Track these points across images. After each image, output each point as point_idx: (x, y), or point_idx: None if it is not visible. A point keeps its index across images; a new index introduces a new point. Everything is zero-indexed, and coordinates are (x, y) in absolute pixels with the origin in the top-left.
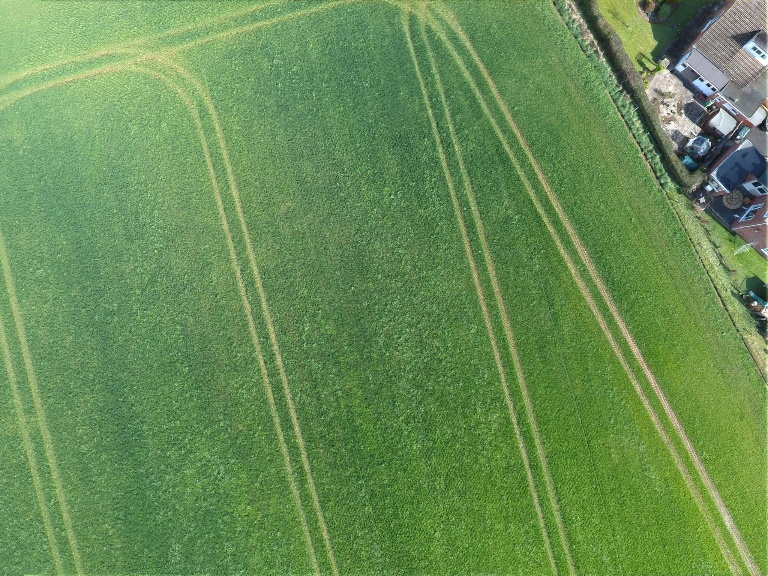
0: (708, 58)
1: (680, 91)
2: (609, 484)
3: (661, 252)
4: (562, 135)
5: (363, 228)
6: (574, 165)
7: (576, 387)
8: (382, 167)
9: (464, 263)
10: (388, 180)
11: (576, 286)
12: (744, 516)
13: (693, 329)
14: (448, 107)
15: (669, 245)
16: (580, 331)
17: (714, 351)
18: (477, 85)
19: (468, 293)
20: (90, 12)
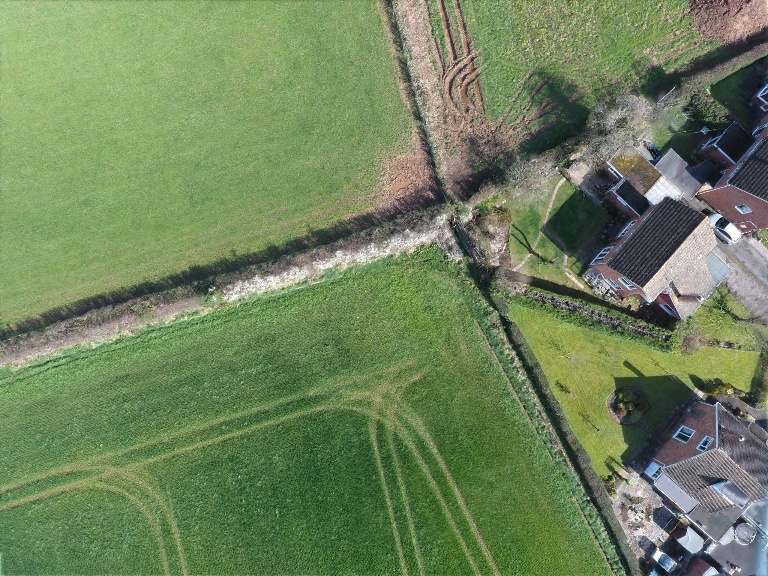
0: (676, 482)
1: (649, 495)
2: None
3: None
4: (527, 545)
5: None
6: None
7: None
8: None
9: None
10: None
11: None
12: None
13: None
14: (412, 520)
15: None
16: None
17: None
18: (443, 495)
19: None
20: (57, 429)
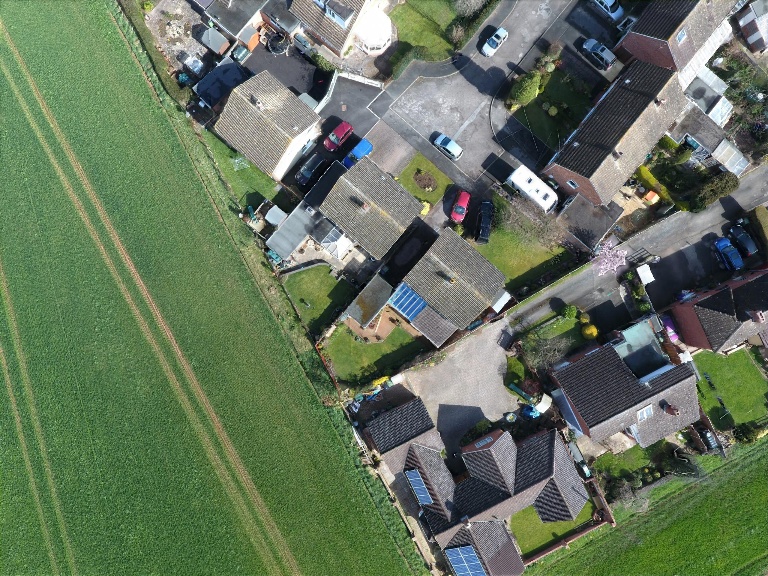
0: None
1: (187, 13)
2: (91, 390)
3: (159, 167)
4: (61, 54)
5: None
6: (72, 83)
7: (61, 296)
8: None
9: None
10: None
11: (67, 199)
12: (234, 423)
13: (190, 242)
14: None
15: (167, 161)
16: (68, 242)
17: (210, 263)
18: None
19: None
20: None
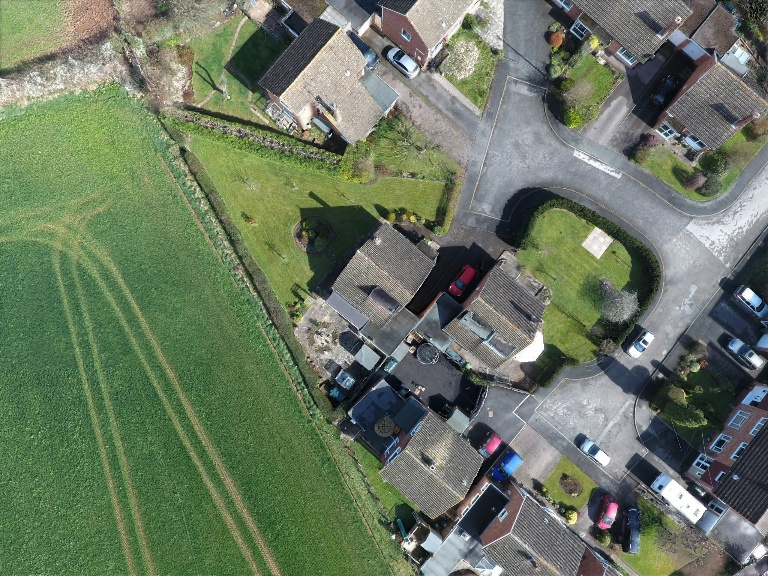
0: (346, 299)
1: (335, 320)
2: None
3: (309, 482)
4: (212, 368)
5: (2, 469)
6: (223, 398)
7: None
8: (25, 407)
9: (104, 500)
10: (30, 420)
11: (220, 519)
12: None
13: (339, 557)
14: (95, 345)
15: (317, 475)
16: (221, 564)
17: None
18: (126, 322)
19: (108, 530)
20: None
